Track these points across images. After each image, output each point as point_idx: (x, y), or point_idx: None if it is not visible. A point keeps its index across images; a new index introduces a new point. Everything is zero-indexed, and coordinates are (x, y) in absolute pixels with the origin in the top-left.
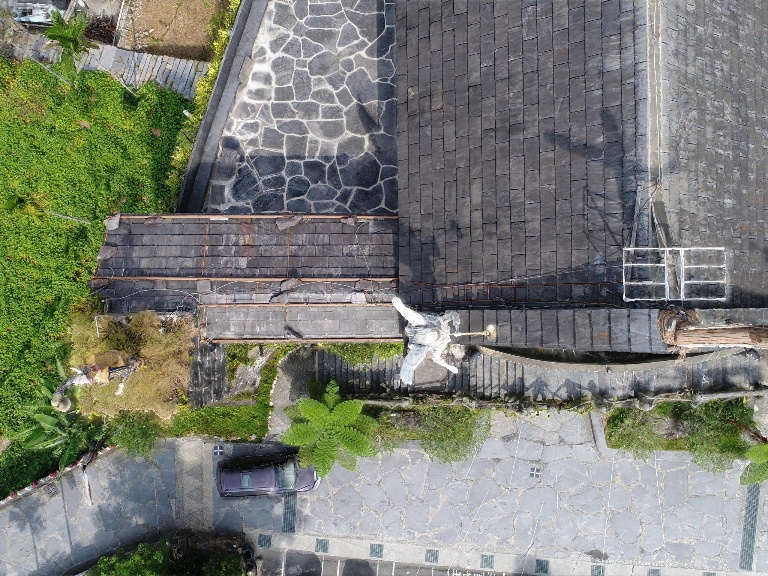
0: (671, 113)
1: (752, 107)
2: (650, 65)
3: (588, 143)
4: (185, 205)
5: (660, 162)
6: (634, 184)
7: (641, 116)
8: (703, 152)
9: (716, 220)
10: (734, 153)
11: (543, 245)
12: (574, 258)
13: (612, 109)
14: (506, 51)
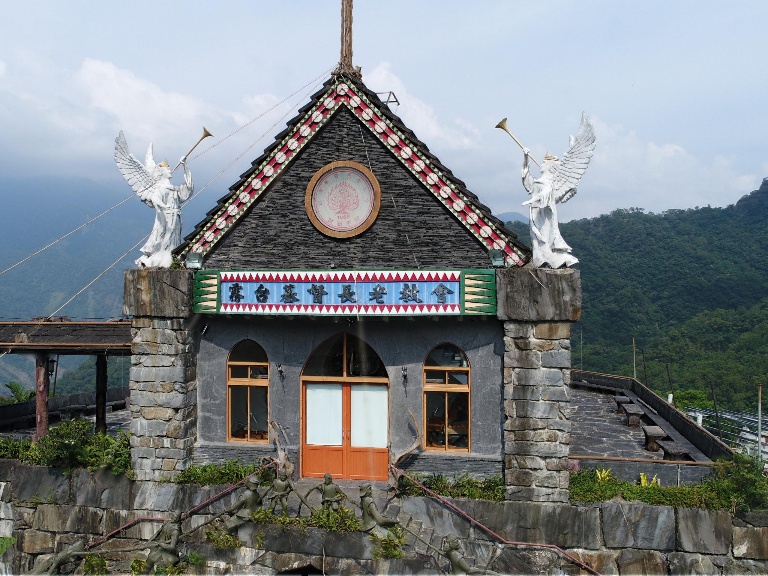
0: None
1: None
2: None
3: None
4: (5, 416)
5: None
6: None
7: None
8: None
9: None
10: None
11: None
12: None
13: None
14: None
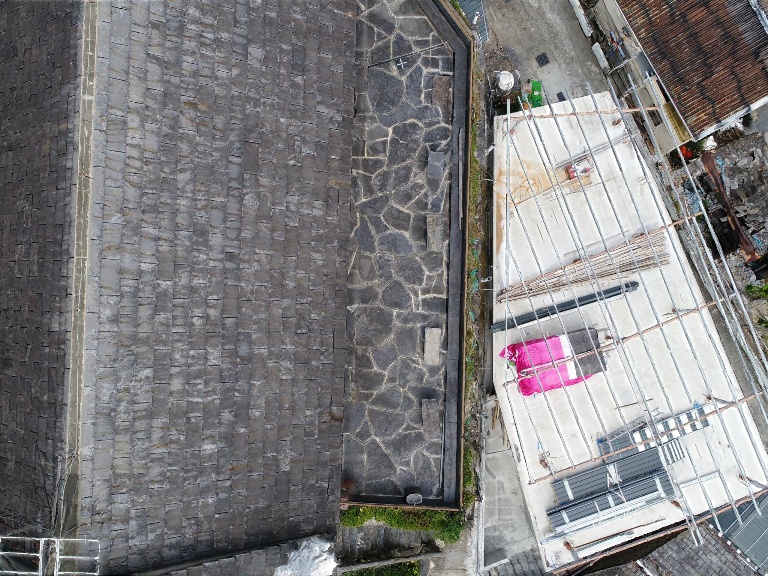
0: (102, 381)
1: (261, 342)
2: (73, 336)
3: (39, 398)
4: None
5: (78, 434)
6: (59, 452)
7: (65, 386)
8: (163, 407)
9: (184, 471)
10: (223, 396)
11: (14, 488)
12: (28, 510)
13: (53, 370)
14: (7, 283)
